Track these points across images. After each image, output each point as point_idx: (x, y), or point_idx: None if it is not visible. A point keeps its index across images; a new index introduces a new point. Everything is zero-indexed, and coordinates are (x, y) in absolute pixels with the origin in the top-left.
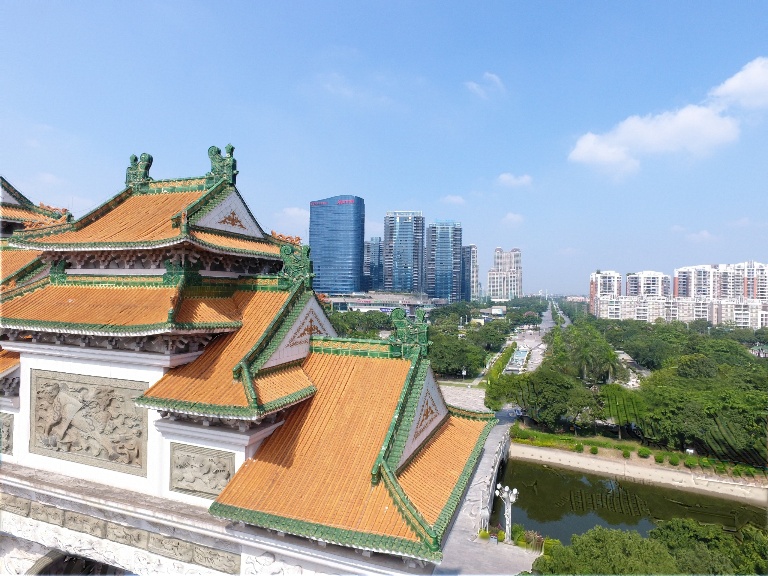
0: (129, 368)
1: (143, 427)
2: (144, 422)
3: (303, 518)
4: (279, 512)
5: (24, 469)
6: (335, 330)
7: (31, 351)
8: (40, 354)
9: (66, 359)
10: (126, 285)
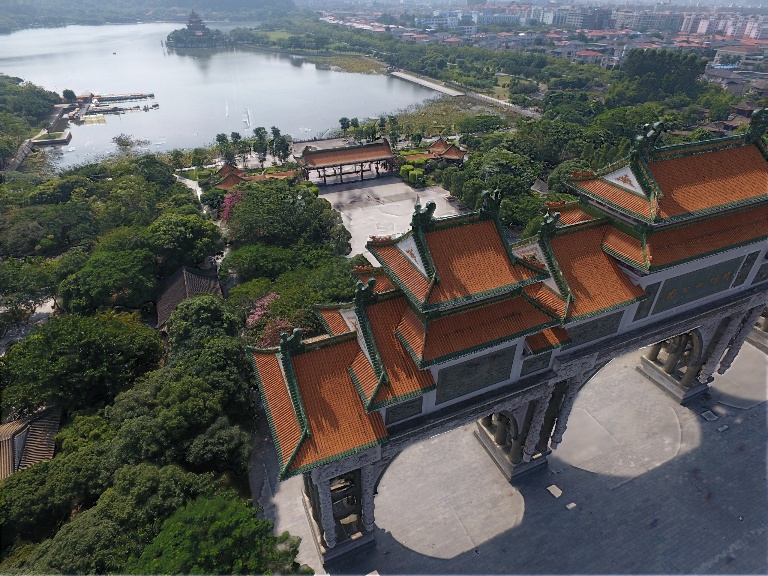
0: None
1: None
2: None
3: None
4: (308, 340)
5: None
6: (369, 350)
7: None
8: None
9: None
10: None
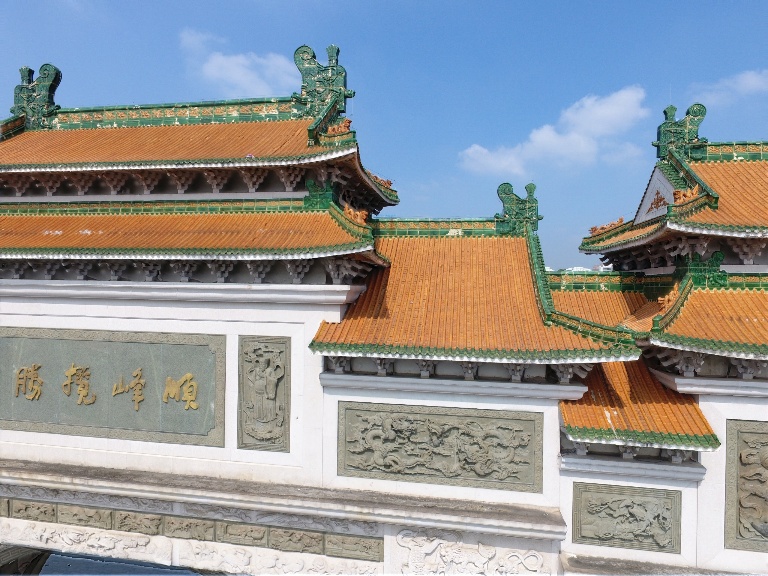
0: None
1: None
2: None
3: None
4: None
5: (732, 575)
6: None
7: (752, 393)
8: (756, 397)
9: None
10: None
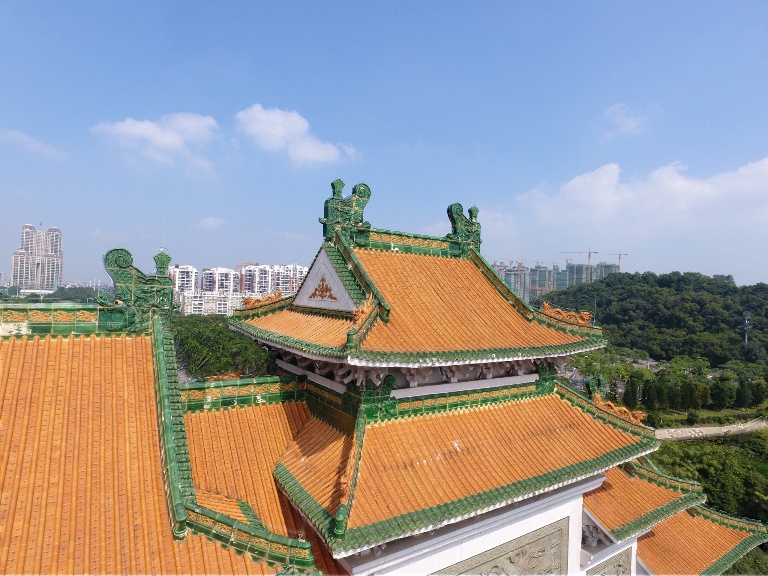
0: (550, 509)
1: (562, 573)
2: (563, 566)
3: (709, 562)
4: None
5: None
6: None
7: (422, 553)
8: None
9: (467, 538)
10: (495, 402)
